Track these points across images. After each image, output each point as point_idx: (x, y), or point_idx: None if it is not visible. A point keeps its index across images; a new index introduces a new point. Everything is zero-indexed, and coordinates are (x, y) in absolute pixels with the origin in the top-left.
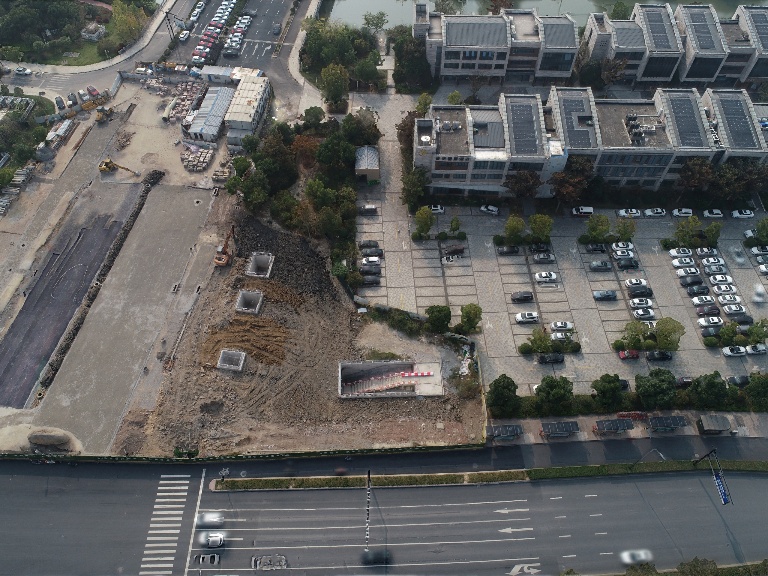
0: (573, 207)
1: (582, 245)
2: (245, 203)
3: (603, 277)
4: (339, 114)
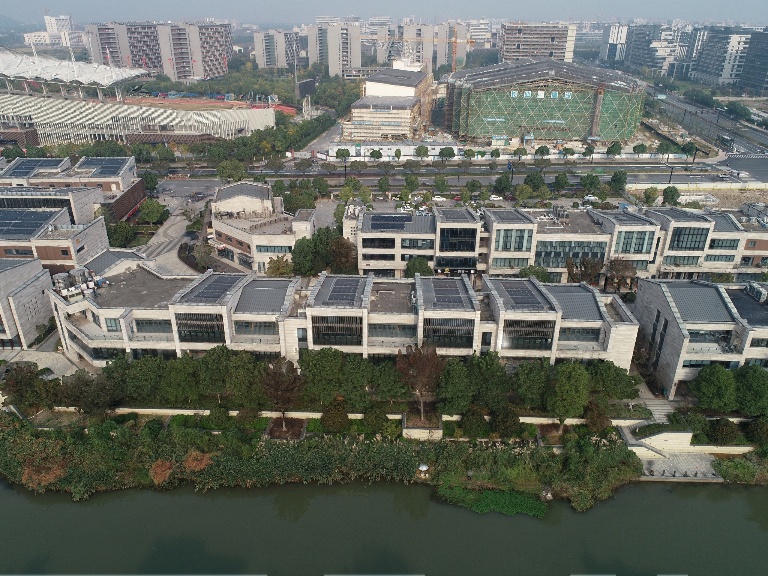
0: None
1: None
2: None
3: None
4: None
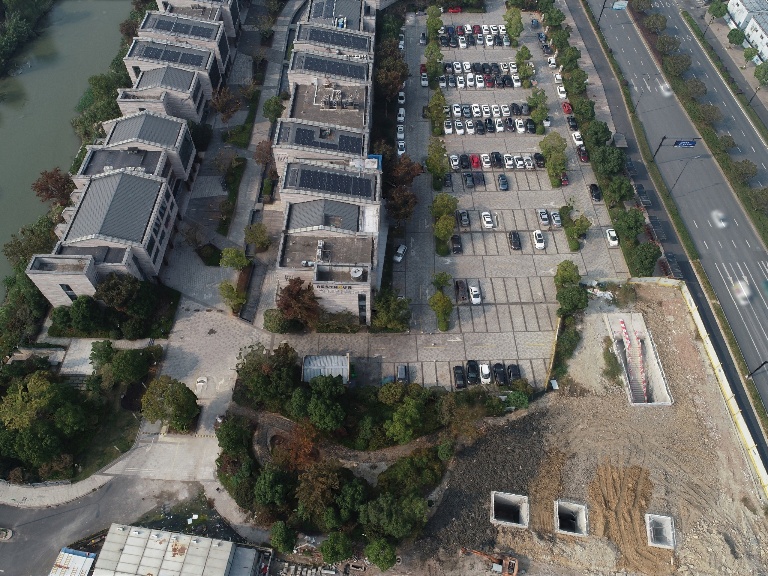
0: (392, 187)
1: (442, 189)
2: (412, 536)
3: (480, 181)
4: (200, 417)
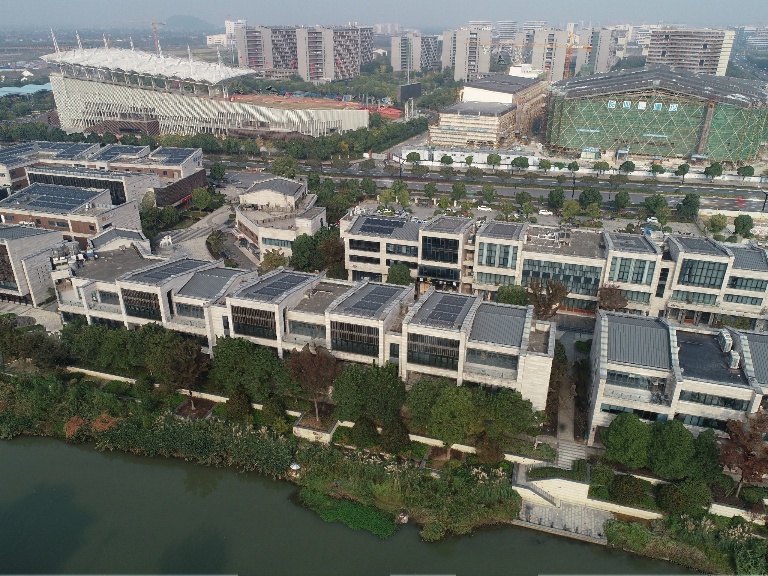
0: None
1: None
2: None
3: None
4: None
